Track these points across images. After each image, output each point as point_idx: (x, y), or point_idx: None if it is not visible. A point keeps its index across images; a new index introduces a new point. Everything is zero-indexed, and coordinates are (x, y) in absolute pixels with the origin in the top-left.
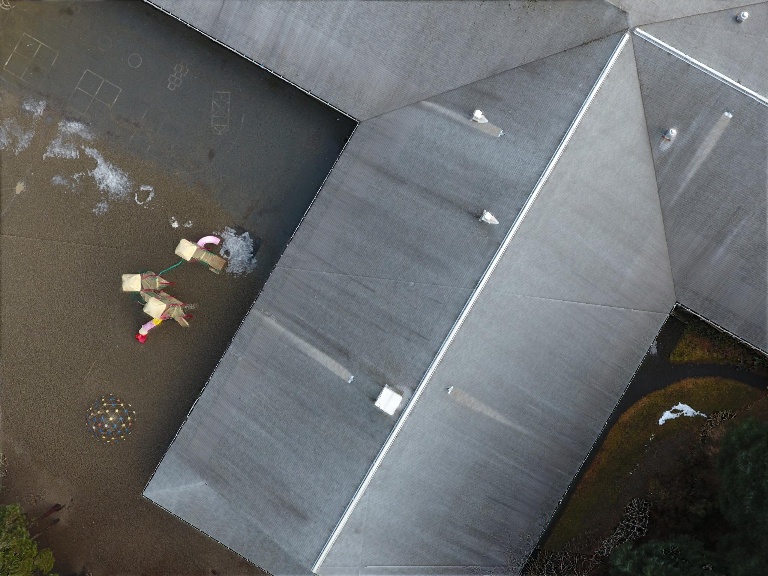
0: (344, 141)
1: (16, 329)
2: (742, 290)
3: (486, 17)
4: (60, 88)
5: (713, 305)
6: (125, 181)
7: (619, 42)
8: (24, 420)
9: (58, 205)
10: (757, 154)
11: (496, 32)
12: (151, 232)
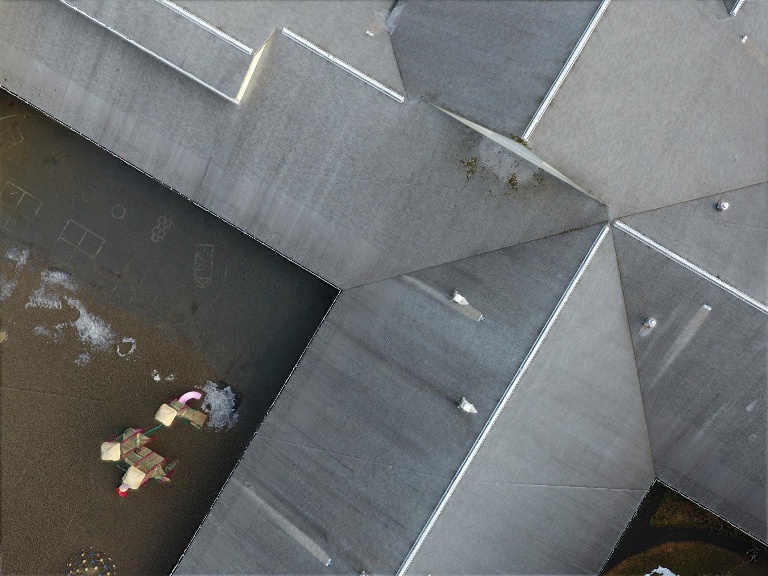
0: (327, 296)
1: None
2: (721, 471)
3: (467, 201)
4: (43, 237)
5: (692, 483)
6: (107, 333)
7: (599, 234)
8: (3, 571)
9: (40, 355)
10: (736, 346)
11: (477, 215)
12: (133, 385)
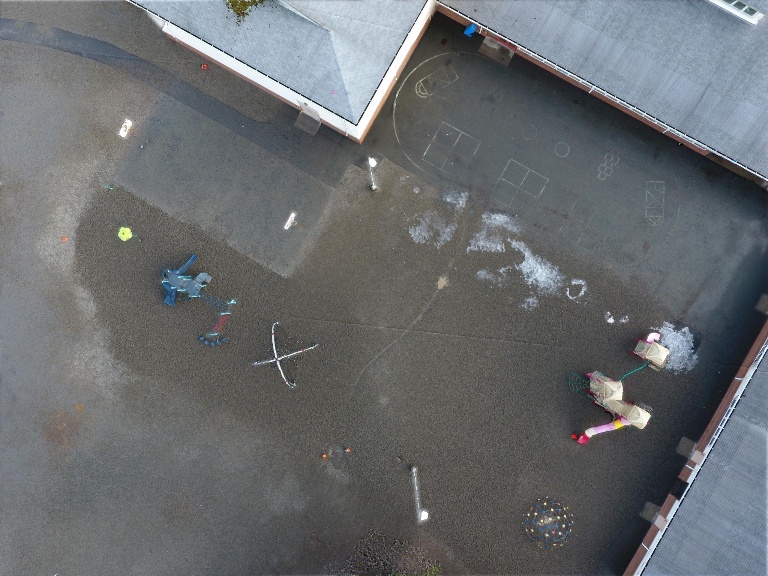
0: None
1: (443, 430)
2: None
3: None
4: (483, 179)
5: None
6: (555, 275)
7: None
8: (454, 524)
9: (484, 300)
10: None
11: None
12: (585, 328)
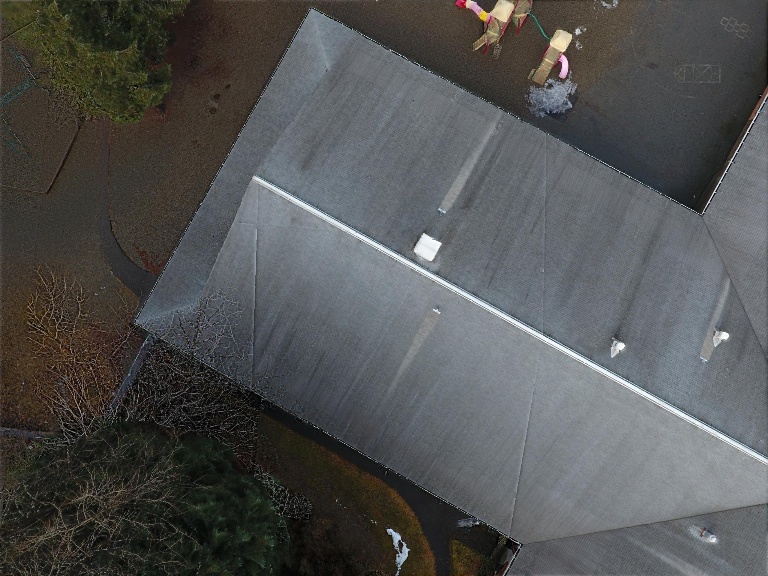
0: None
1: None
2: None
3: None
4: None
5: None
6: None
7: None
8: None
9: None
10: None
11: None
12: (570, 7)
